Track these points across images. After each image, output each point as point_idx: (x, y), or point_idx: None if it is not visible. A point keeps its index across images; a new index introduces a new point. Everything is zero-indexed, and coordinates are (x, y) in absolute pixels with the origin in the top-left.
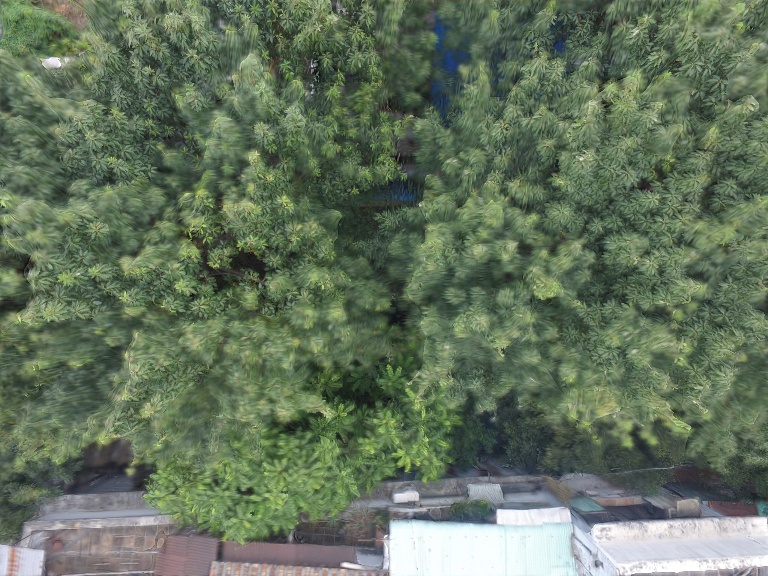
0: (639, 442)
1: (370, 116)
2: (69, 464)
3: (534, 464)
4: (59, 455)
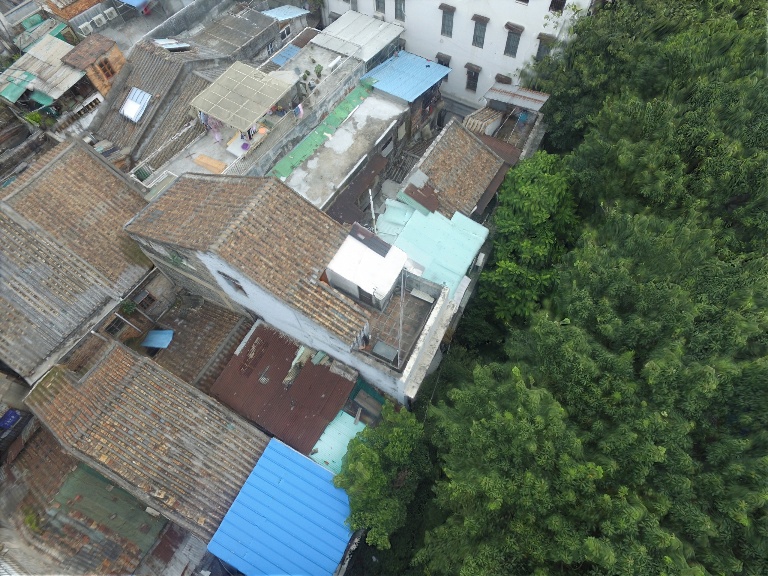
0: (450, 401)
1: (763, 254)
2: (557, 140)
3: None
4: None
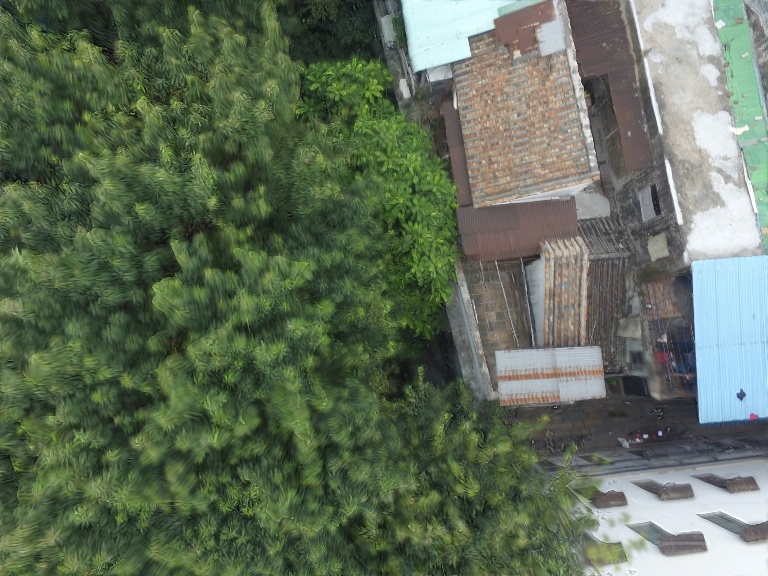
0: None
1: None
2: None
3: (368, 11)
4: (399, 325)
